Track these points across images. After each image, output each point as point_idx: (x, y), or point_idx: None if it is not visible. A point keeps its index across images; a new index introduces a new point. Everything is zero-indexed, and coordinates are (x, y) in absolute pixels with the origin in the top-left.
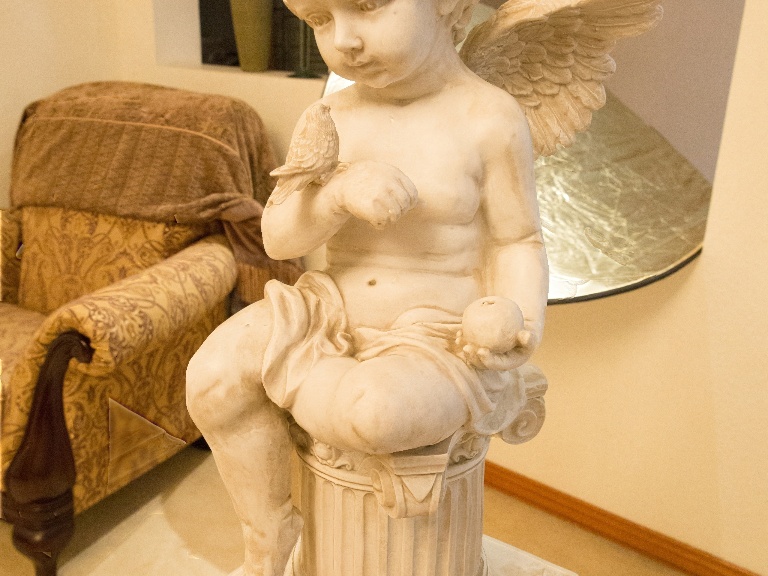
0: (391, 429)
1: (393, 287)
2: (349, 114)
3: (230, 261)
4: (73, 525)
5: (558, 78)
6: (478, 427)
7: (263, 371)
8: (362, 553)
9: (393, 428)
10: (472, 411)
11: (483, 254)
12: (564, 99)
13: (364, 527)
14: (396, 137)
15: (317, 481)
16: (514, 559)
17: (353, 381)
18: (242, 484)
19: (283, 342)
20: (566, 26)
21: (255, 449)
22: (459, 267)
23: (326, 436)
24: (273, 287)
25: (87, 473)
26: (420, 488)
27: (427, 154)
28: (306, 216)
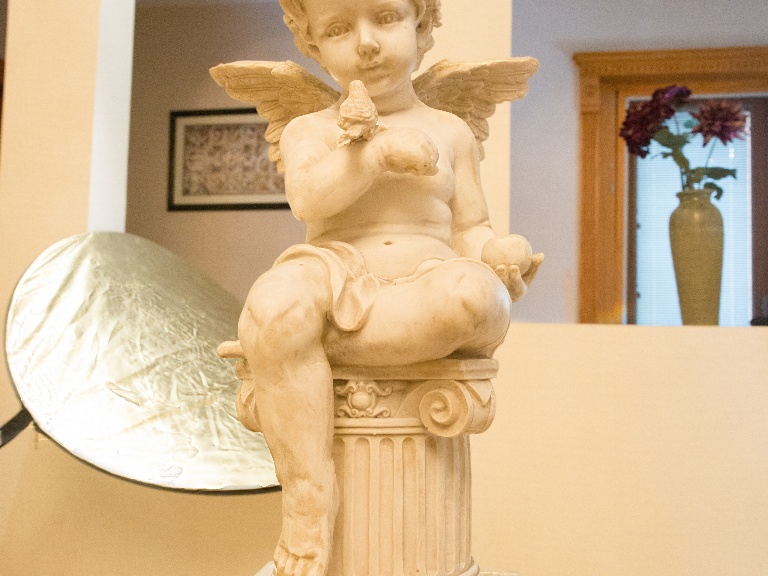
0: (493, 300)
1: (410, 242)
2: None
3: None
4: None
5: None
6: None
7: (337, 293)
8: (402, 509)
9: (494, 300)
10: None
11: None
12: None
13: (403, 478)
14: None
15: (347, 443)
16: None
17: (449, 269)
18: (304, 427)
19: (344, 273)
20: (471, 89)
21: (320, 383)
22: (447, 237)
23: (417, 334)
24: (305, 244)
25: None
26: (484, 391)
27: None
28: (355, 165)
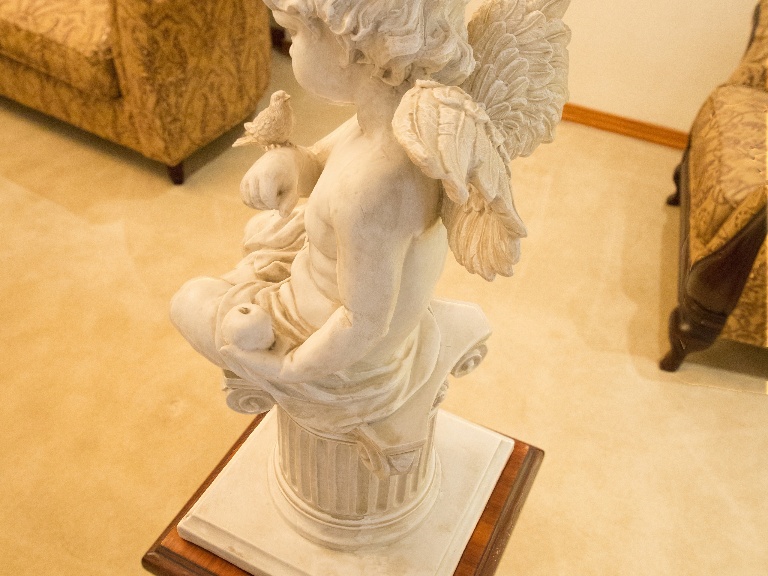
0: None
1: None
2: None
3: None
4: (713, 343)
5: None
6: (274, 396)
7: None
8: None
9: None
10: None
11: None
12: (491, 225)
13: None
14: None
15: None
16: (417, 567)
17: None
18: None
19: (258, 239)
20: None
21: None
22: (320, 285)
23: None
24: None
25: (747, 314)
26: None
27: None
28: None
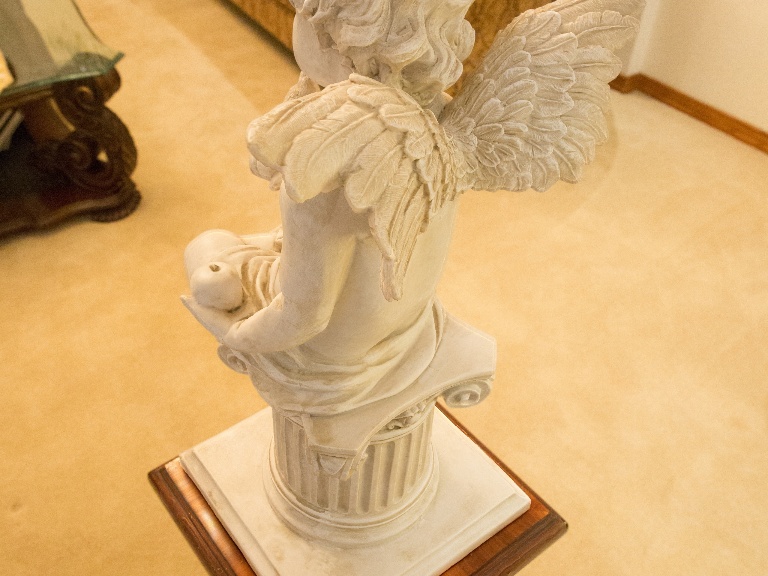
0: None
1: None
2: None
3: None
4: None
5: None
6: None
7: None
8: None
9: None
10: None
11: None
12: None
13: None
14: None
15: None
16: None
17: None
18: None
19: None
20: None
21: None
22: None
23: None
24: None
25: None
26: None
27: None
28: None
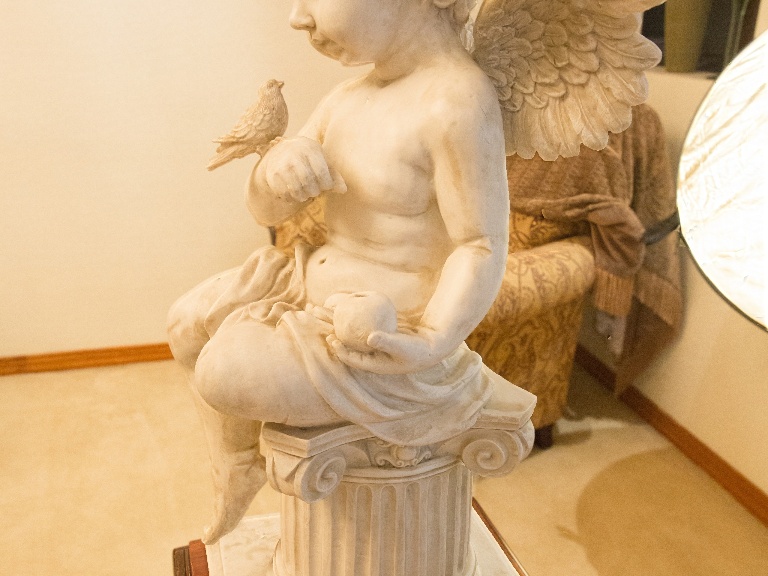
0: (215, 390)
1: (329, 268)
2: (350, 94)
3: (587, 264)
4: None
5: (584, 64)
6: (375, 430)
7: None
8: (294, 523)
9: (217, 389)
10: (331, 404)
11: (442, 253)
12: (594, 90)
13: (295, 498)
14: (361, 118)
15: None
16: None
17: None
18: (203, 420)
19: (228, 298)
20: (570, 1)
21: None
22: (398, 260)
23: None
24: None
25: None
26: (283, 466)
27: (372, 137)
28: (252, 184)
